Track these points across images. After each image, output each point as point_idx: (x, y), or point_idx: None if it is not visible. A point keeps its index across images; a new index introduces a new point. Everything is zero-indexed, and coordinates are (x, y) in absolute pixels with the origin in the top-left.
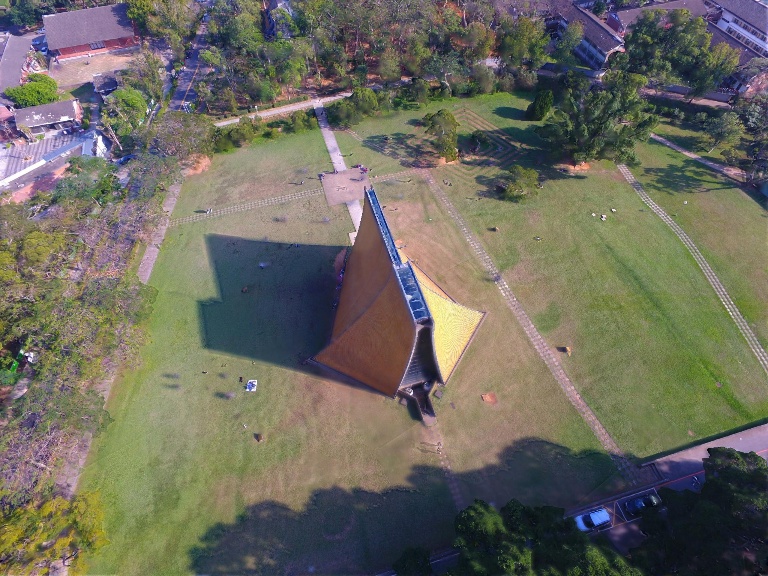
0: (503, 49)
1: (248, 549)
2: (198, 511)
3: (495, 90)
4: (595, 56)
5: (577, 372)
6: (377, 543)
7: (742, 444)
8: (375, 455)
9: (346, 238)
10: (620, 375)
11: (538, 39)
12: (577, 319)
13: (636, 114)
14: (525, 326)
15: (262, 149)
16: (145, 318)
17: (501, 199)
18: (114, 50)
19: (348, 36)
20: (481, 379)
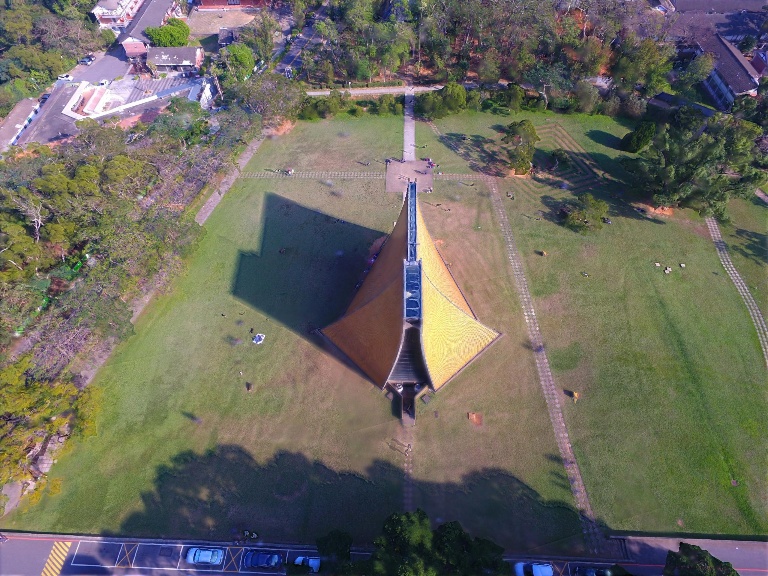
0: (616, 70)
1: (206, 481)
2: (177, 434)
3: (596, 111)
4: (724, 95)
5: (577, 421)
6: (318, 517)
7: (736, 554)
8: (346, 436)
9: (390, 226)
10: (623, 438)
11: (658, 65)
12: (597, 367)
13: (742, 167)
14: (538, 358)
15: (343, 124)
16: (188, 253)
17: (561, 225)
18: (246, 8)
19: (459, 30)
20: (473, 397)
